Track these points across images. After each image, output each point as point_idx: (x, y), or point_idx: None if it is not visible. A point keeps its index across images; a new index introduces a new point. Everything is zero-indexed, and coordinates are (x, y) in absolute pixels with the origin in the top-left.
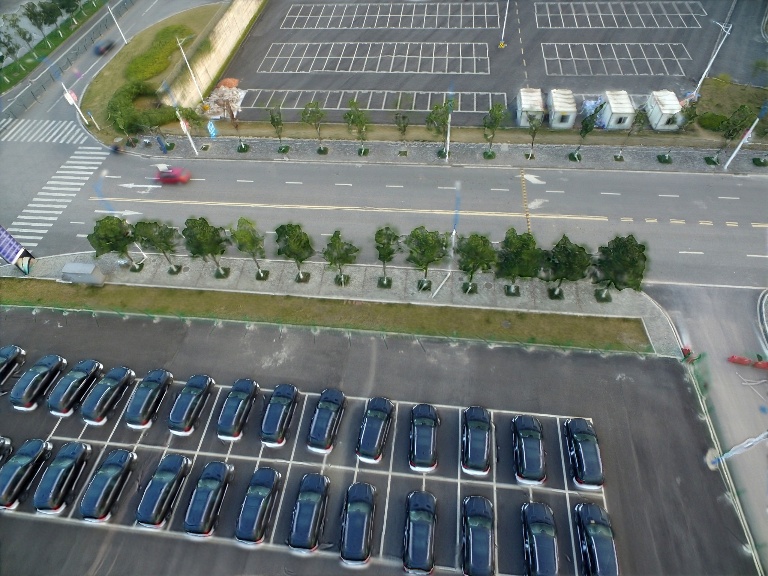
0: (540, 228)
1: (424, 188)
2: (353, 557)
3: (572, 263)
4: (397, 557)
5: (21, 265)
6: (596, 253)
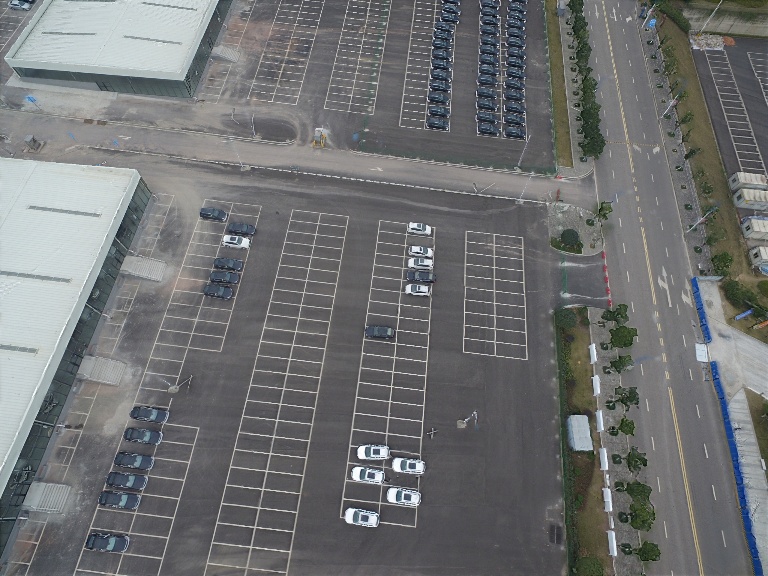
0: (620, 146)
1: (638, 108)
2: None
3: None
4: None
5: None
6: None
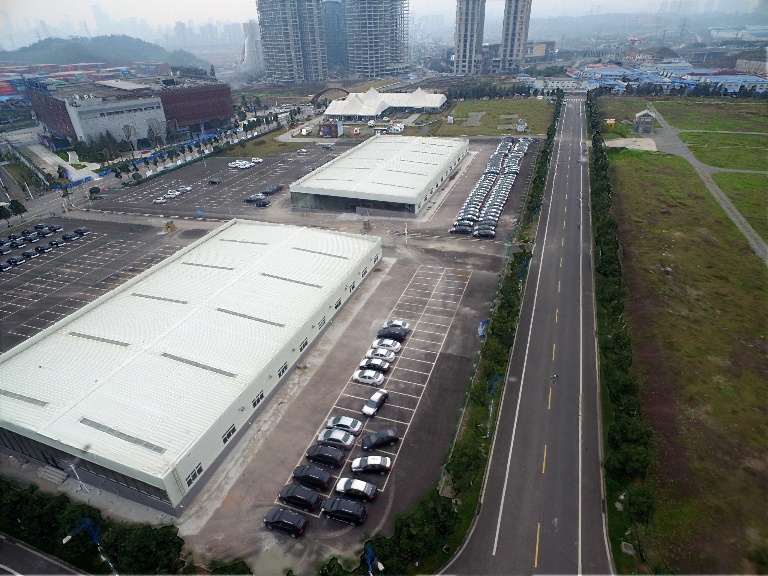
0: None
1: None
2: (6, 250)
3: (4, 210)
4: (17, 249)
5: None
6: (8, 208)
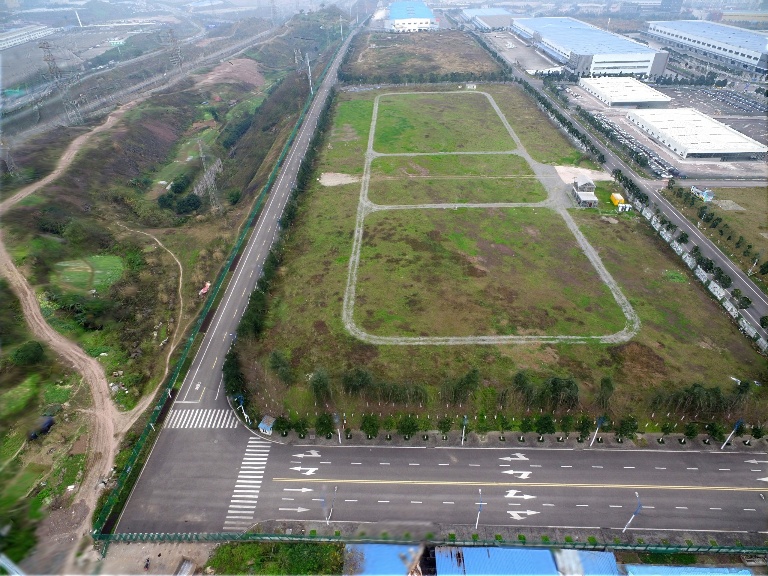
0: None
1: None
2: None
3: None
4: None
5: (744, 92)
6: None
